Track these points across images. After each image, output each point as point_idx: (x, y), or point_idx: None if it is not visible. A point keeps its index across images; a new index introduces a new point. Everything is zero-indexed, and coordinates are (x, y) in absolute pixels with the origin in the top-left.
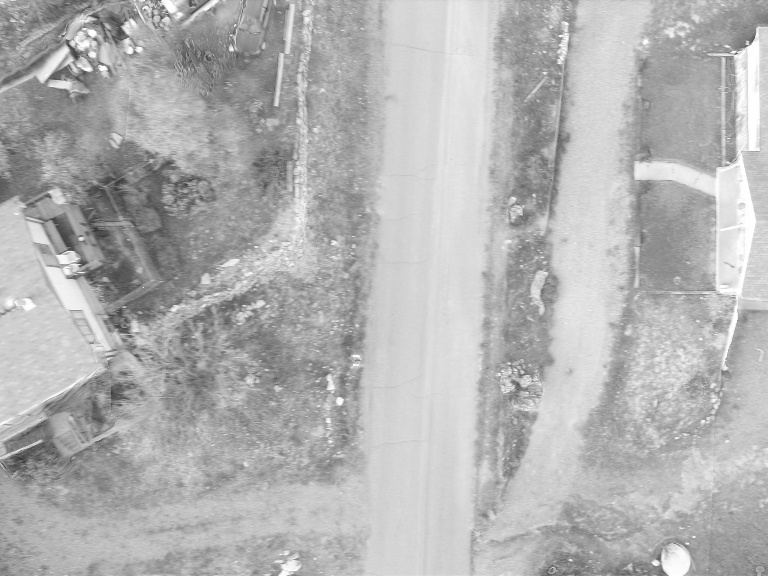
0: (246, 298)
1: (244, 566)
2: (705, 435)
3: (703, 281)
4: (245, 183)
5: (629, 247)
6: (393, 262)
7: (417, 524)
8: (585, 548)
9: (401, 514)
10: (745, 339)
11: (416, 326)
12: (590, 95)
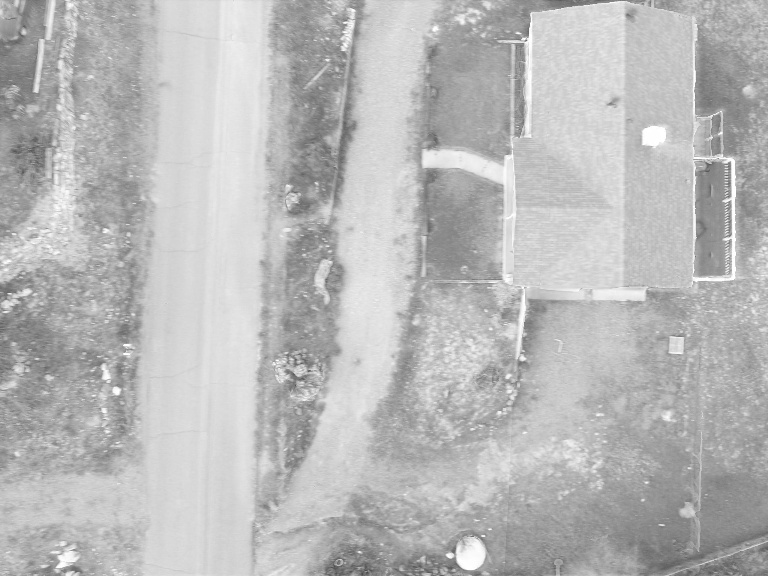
0: (12, 286)
1: (18, 557)
2: (502, 426)
3: (490, 270)
4: (4, 170)
5: (416, 236)
6: (169, 250)
7: (197, 515)
8: (375, 540)
9: (180, 505)
10: (544, 329)
11: (193, 315)
12: (378, 82)
